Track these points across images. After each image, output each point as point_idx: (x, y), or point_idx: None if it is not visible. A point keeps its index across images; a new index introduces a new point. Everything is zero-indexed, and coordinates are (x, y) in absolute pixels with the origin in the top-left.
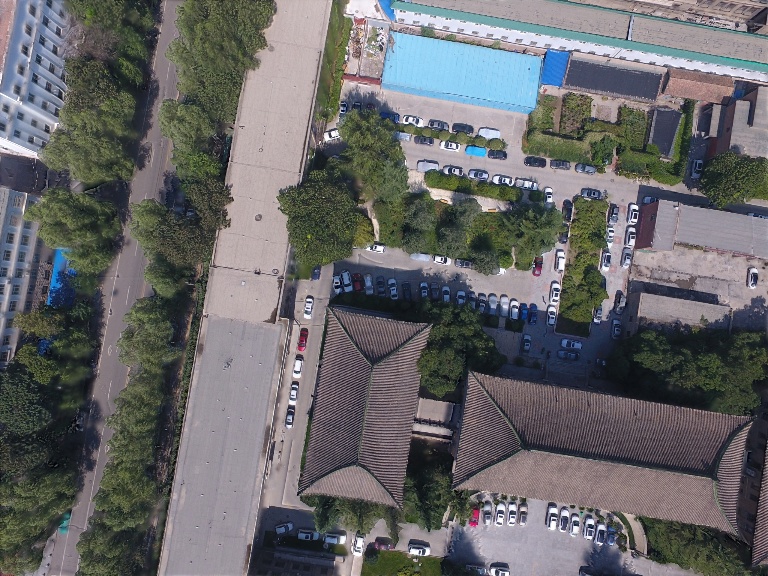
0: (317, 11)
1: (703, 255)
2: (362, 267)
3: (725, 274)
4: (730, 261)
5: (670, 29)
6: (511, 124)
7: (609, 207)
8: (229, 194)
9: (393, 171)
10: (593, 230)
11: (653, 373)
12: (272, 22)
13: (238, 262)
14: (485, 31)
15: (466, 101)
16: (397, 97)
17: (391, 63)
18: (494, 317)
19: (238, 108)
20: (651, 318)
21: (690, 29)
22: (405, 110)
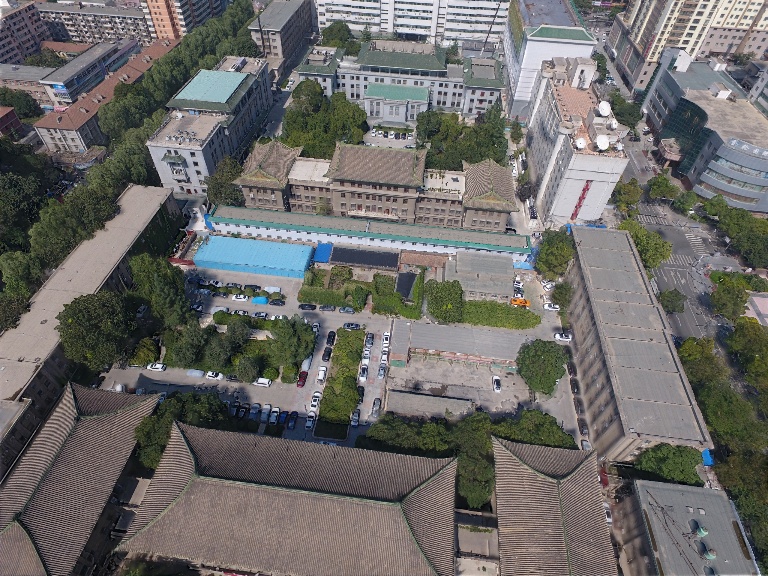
0: (147, 213)
1: (451, 368)
2: (140, 384)
3: (473, 382)
4: (475, 372)
5: (395, 227)
6: (291, 285)
7: (366, 335)
8: (29, 308)
9: (164, 288)
10: (352, 350)
11: (381, 444)
12: (113, 218)
13: (8, 353)
14: (275, 234)
15: (256, 271)
16: (207, 271)
17: (203, 250)
18: (252, 421)
19: (65, 259)
20: (398, 412)
21: (409, 227)
22: (211, 278)
